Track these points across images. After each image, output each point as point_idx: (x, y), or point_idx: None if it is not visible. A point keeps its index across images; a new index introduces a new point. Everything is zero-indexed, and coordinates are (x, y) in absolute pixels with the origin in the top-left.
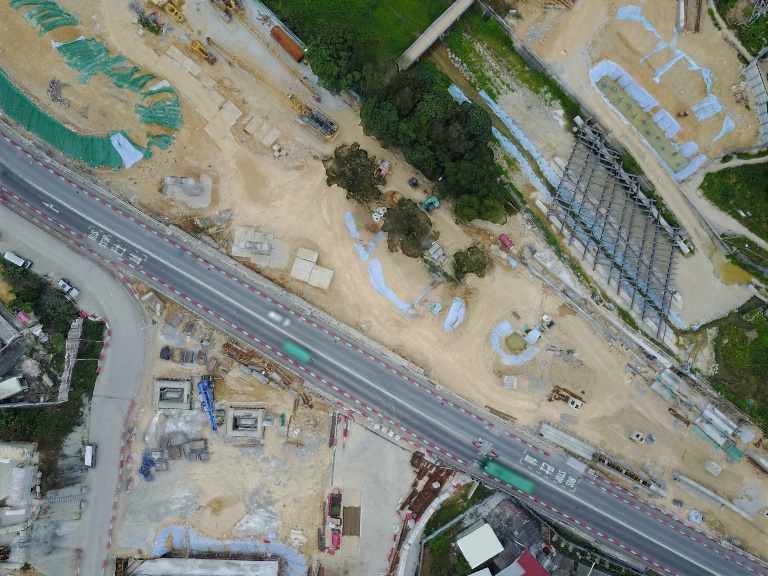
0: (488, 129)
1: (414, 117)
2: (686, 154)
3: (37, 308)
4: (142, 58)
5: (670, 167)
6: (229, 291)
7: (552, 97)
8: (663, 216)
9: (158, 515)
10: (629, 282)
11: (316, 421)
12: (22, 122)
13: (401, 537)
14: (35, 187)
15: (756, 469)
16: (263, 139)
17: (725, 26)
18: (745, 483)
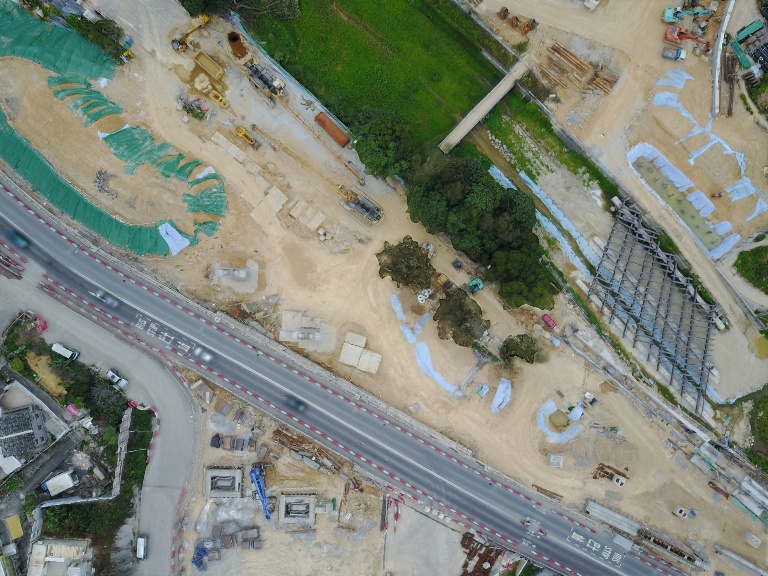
0: (533, 215)
1: (464, 208)
2: (720, 232)
3: (87, 402)
4: (187, 145)
5: (705, 245)
6: (278, 377)
7: (590, 178)
8: (699, 293)
9: None
10: (668, 358)
11: (367, 505)
12: (67, 211)
13: None
14: (81, 276)
15: None
16: (308, 223)
17: (757, 110)
18: None
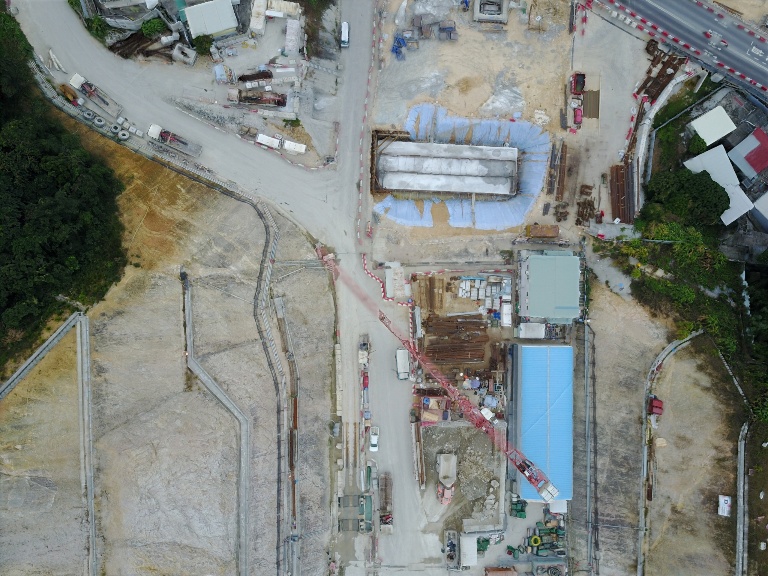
0: None
1: None
2: None
3: None
4: None
5: None
6: None
7: None
8: None
9: (409, 93)
10: None
11: (556, 9)
12: None
13: (637, 119)
14: None
15: None
16: None
17: None
18: None
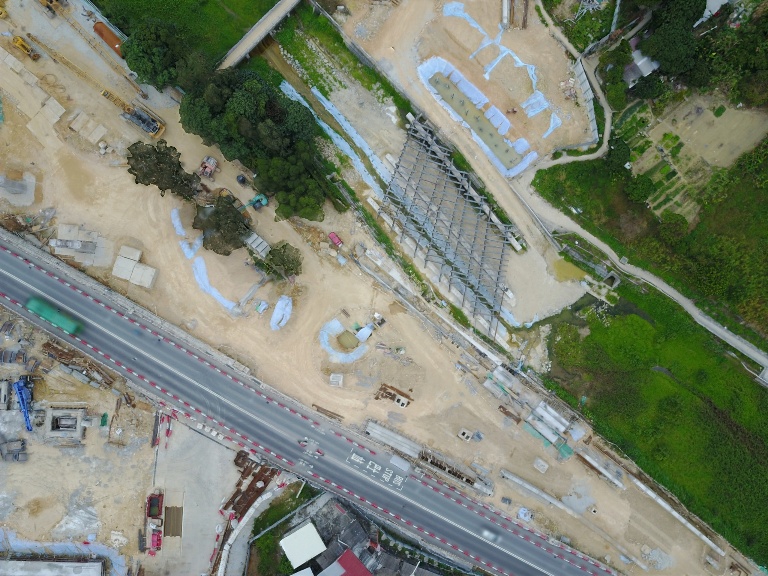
0: (308, 126)
1: (225, 114)
2: (518, 151)
3: None
4: None
5: (503, 164)
6: (50, 290)
7: (384, 94)
8: (495, 213)
9: None
10: (461, 279)
11: (138, 421)
12: None
13: (224, 537)
14: None
15: (585, 466)
16: (89, 136)
17: (552, 22)
18: (574, 480)
